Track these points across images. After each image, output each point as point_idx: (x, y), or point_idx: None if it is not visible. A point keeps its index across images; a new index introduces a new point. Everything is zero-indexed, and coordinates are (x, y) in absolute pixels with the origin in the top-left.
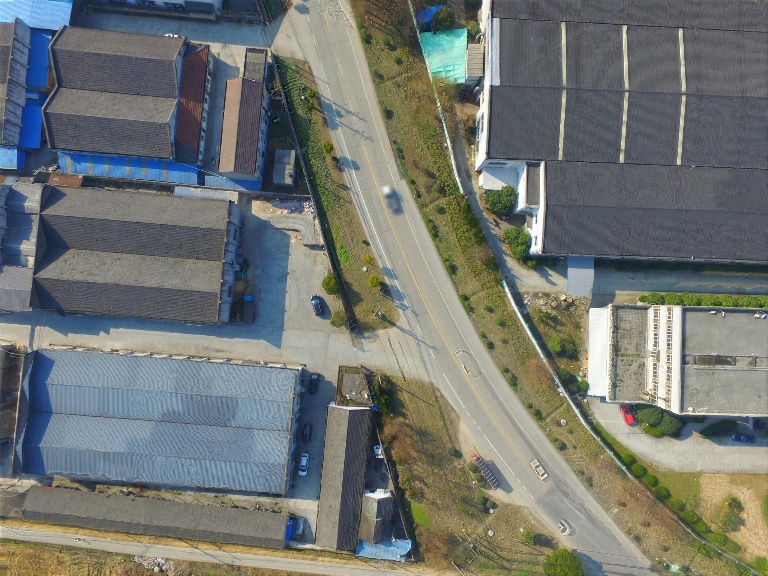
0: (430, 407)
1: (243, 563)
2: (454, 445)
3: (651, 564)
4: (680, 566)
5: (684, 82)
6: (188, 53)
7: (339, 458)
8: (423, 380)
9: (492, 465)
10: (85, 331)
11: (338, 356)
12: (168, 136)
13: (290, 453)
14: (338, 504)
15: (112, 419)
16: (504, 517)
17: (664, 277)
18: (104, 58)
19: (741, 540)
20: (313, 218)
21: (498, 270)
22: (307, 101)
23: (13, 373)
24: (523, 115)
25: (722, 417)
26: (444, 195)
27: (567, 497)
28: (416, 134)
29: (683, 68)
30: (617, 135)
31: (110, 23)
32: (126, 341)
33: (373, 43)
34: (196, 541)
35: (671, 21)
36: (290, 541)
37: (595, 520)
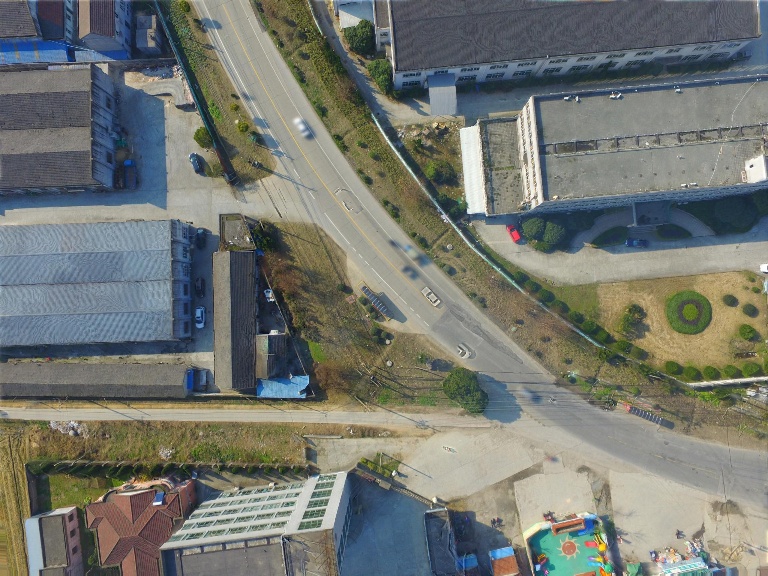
0: (316, 247)
1: (152, 418)
2: (343, 282)
3: (556, 379)
4: (586, 378)
5: None
6: None
7: (226, 299)
8: (306, 222)
9: (383, 297)
10: None
11: (222, 210)
12: (28, 11)
13: (177, 298)
14: (229, 343)
15: (8, 286)
16: (401, 346)
17: (536, 94)
18: None
19: (648, 346)
20: (182, 79)
21: (365, 104)
22: None
23: None
24: None
25: (612, 225)
26: (306, 41)
27: (463, 321)
28: None
29: None
30: None
31: None
32: (21, 220)
33: None
34: (104, 400)
35: None
36: (195, 392)
37: (494, 341)
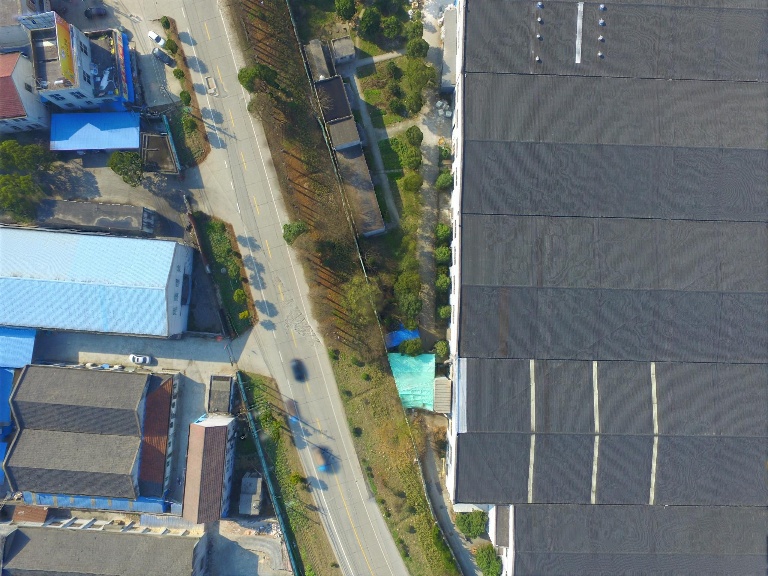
0: None
1: None
2: None
3: None
4: None
5: (656, 423)
6: (151, 389)
7: None
8: None
9: None
10: None
11: None
12: (131, 484)
13: None
14: None
15: None
16: None
17: None
18: (65, 407)
19: None
20: (281, 542)
21: None
22: (274, 420)
23: None
24: (491, 460)
25: None
26: (414, 514)
27: None
28: (385, 452)
29: (655, 407)
30: (588, 475)
31: (74, 342)
32: None
33: (341, 359)
34: None
35: (643, 356)
36: None
37: None
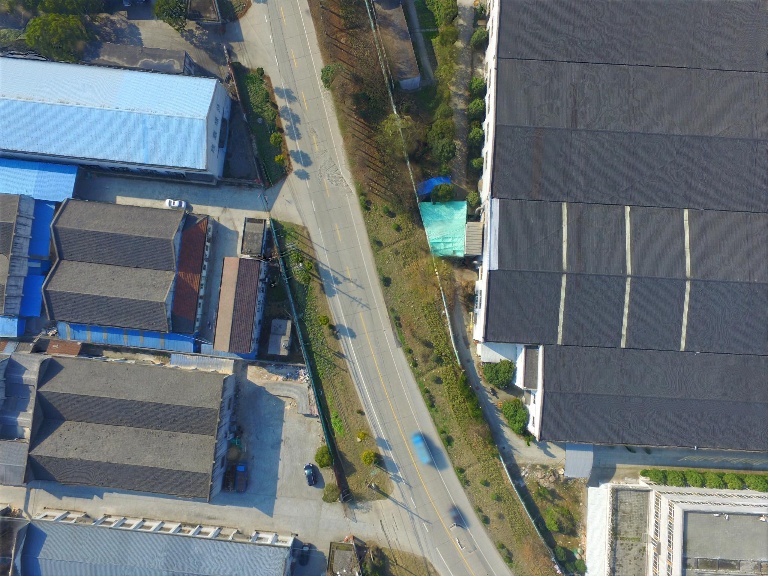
0: None
1: None
2: None
3: None
4: None
5: (688, 267)
6: (187, 226)
7: None
8: (416, 554)
9: None
10: (79, 495)
11: (330, 526)
12: (165, 313)
13: None
14: None
15: None
16: None
17: (667, 451)
18: (104, 236)
19: None
20: (308, 387)
21: (494, 445)
22: (305, 267)
23: (7, 536)
24: (521, 299)
25: None
26: (441, 365)
27: None
28: (414, 302)
29: (688, 252)
30: (618, 319)
31: (113, 187)
32: (119, 506)
33: (372, 209)
34: None
35: (676, 202)
36: None
37: None
